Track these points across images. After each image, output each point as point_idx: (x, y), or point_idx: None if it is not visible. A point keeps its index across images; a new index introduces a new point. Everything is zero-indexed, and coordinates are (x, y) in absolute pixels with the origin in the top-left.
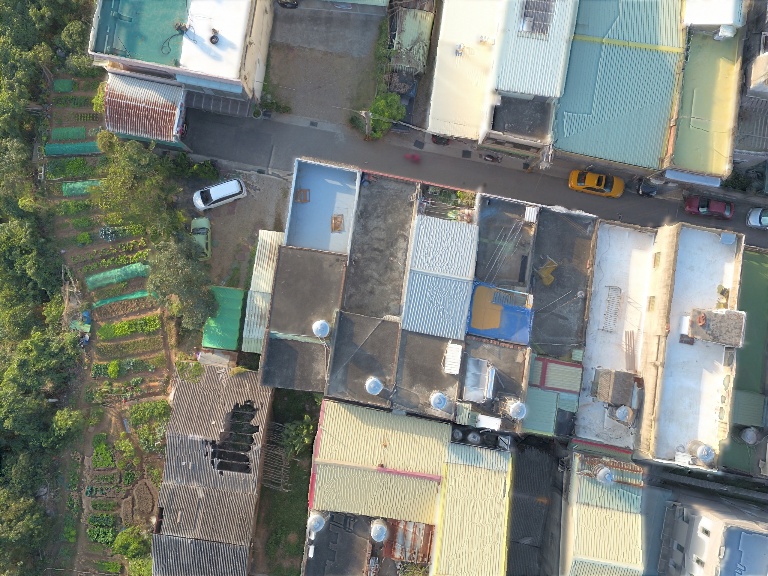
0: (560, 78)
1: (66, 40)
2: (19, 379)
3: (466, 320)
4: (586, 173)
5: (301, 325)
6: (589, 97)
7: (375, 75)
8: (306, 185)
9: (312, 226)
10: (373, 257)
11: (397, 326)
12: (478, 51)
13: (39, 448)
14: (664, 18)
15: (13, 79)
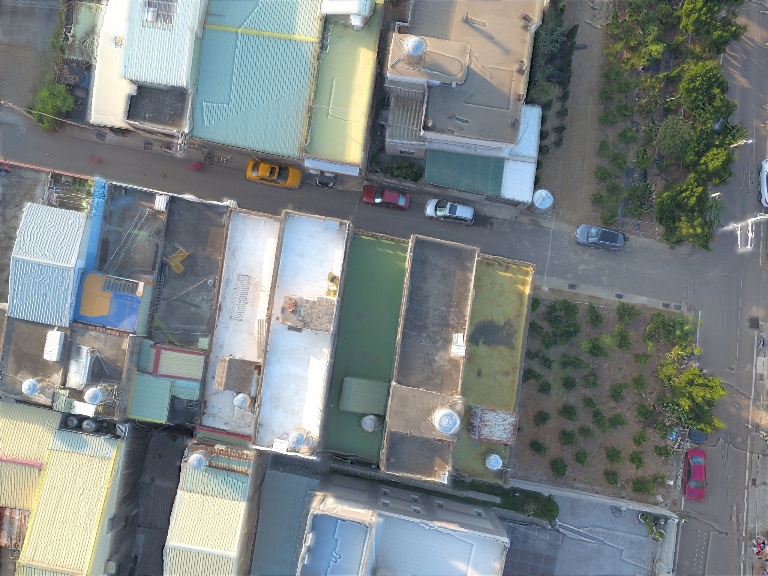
0: (186, 68)
1: None
2: None
3: (69, 307)
4: (259, 164)
5: None
6: (227, 87)
7: None
8: None
9: None
10: (10, 246)
11: (4, 313)
12: None
13: None
14: (303, 9)
15: None
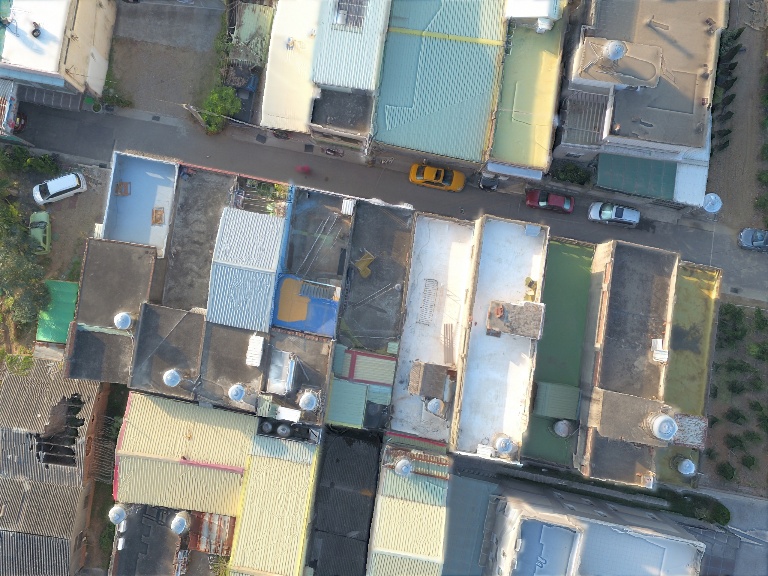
0: (375, 71)
1: None
2: None
3: (270, 312)
4: (424, 167)
5: (109, 317)
6: (410, 90)
7: None
8: (127, 178)
9: (132, 219)
10: (193, 250)
11: (202, 318)
12: (309, 45)
13: None
14: (486, 11)
15: None
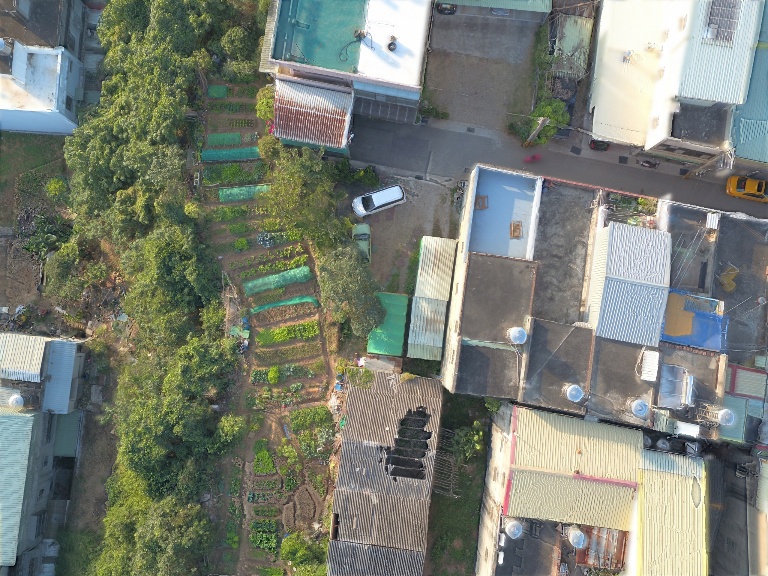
0: (743, 85)
1: (227, 46)
2: (183, 385)
3: (661, 327)
4: (746, 179)
5: (492, 332)
6: (766, 104)
7: (532, 81)
8: (484, 192)
9: (491, 232)
10: (552, 263)
11: (590, 333)
12: (646, 57)
13: (202, 454)
14: None
15: (174, 85)
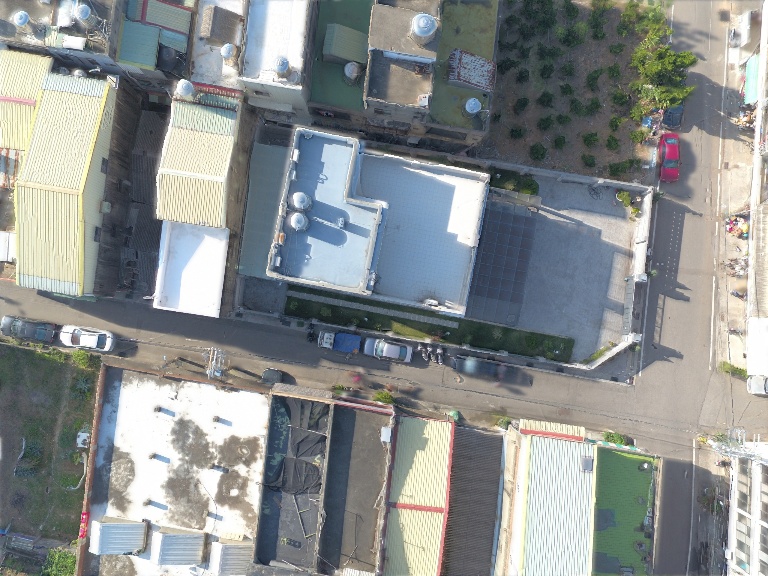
0: None
1: None
2: None
3: None
4: None
5: None
6: None
7: None
8: None
9: None
10: None
11: None
12: None
13: None
14: None
15: None
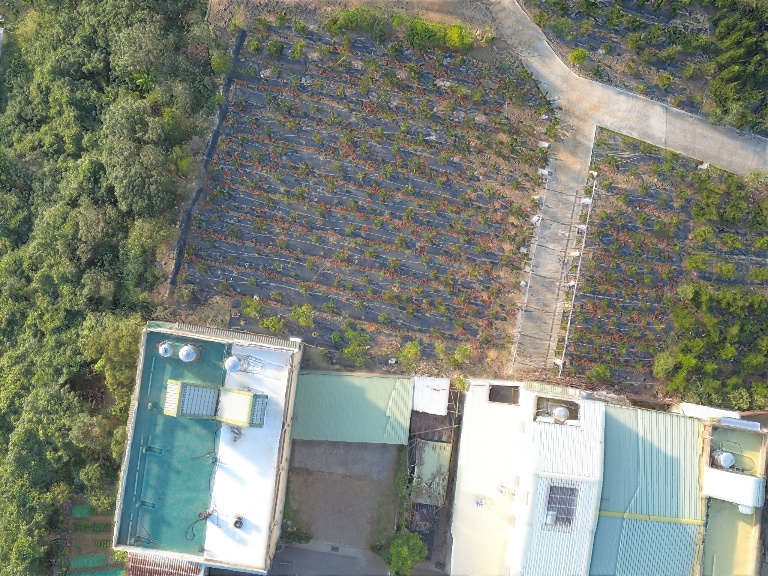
0: (584, 567)
1: (85, 483)
2: None
3: None
4: None
5: None
6: (611, 569)
7: (395, 498)
8: None
9: None
10: None
11: None
12: (499, 501)
13: None
14: (683, 487)
15: (32, 523)
